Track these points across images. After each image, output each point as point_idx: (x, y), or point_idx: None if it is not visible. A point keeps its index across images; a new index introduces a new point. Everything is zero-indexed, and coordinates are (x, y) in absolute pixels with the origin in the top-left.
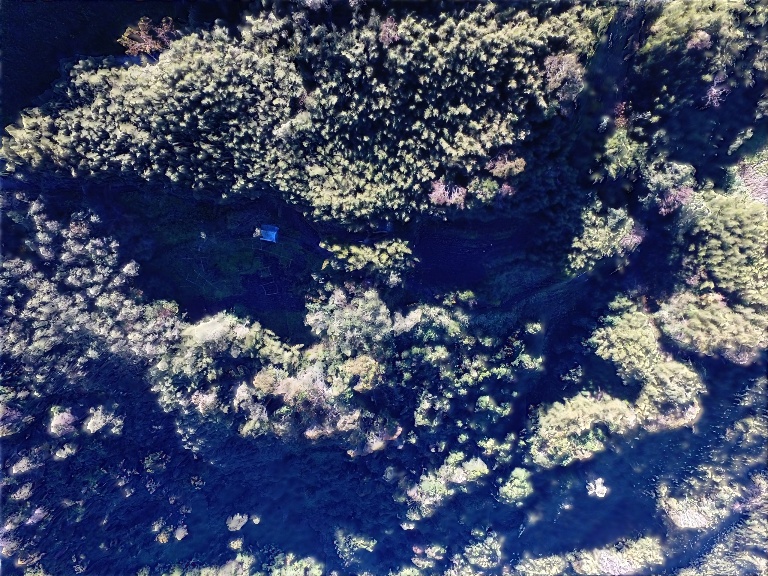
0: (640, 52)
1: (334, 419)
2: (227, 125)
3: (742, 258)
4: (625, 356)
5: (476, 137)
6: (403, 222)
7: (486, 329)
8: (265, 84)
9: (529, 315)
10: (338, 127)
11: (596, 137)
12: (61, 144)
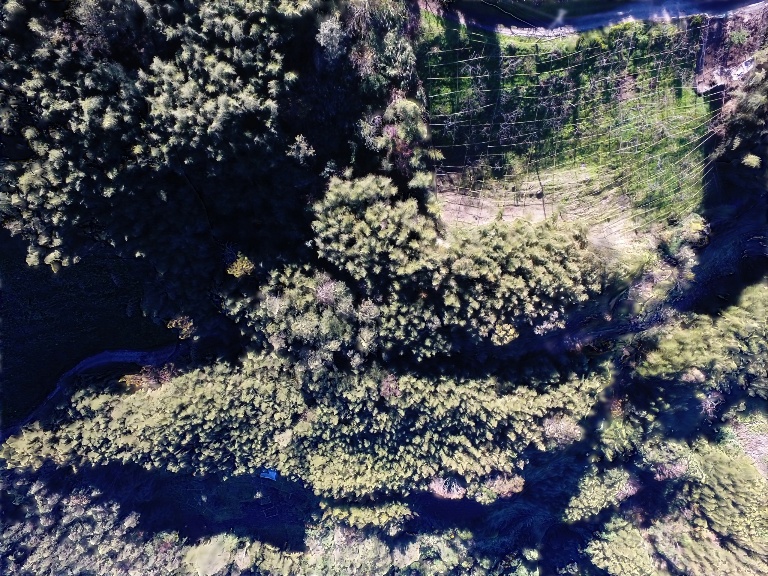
0: (636, 370)
1: None
2: (228, 435)
3: (735, 512)
4: (620, 571)
5: (476, 459)
6: (403, 497)
7: (484, 549)
8: (266, 404)
9: (526, 539)
10: (339, 435)
11: (593, 435)
12: (62, 453)
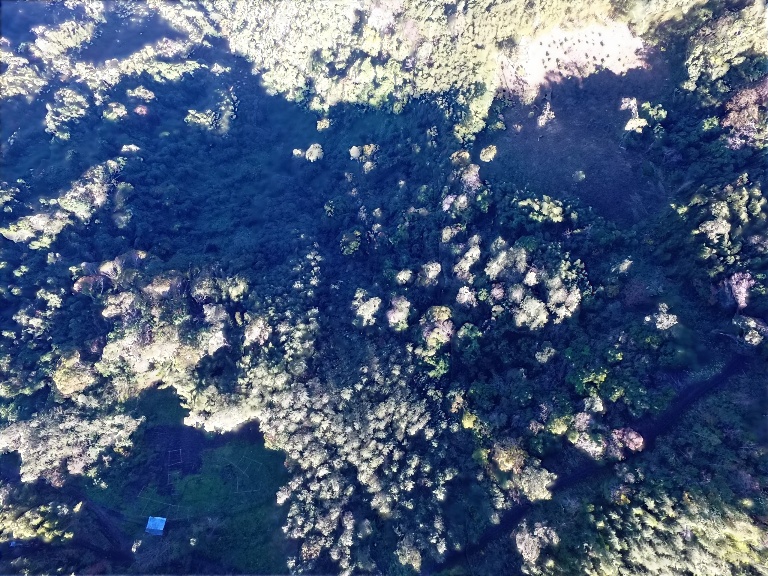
0: None
1: (147, 298)
2: None
3: None
4: None
5: None
6: None
7: None
8: None
9: None
10: None
11: None
12: None
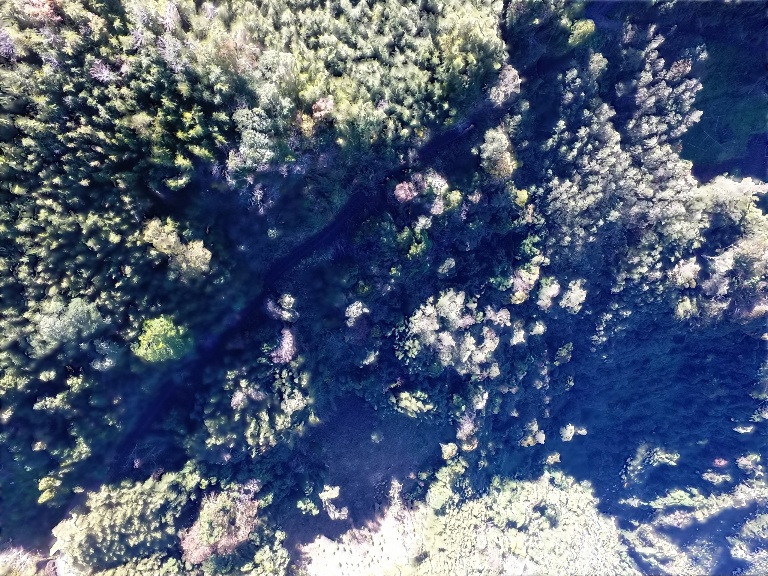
0: None
1: None
2: None
3: None
4: None
5: None
6: None
7: None
8: None
9: None
10: None
11: None
12: None
